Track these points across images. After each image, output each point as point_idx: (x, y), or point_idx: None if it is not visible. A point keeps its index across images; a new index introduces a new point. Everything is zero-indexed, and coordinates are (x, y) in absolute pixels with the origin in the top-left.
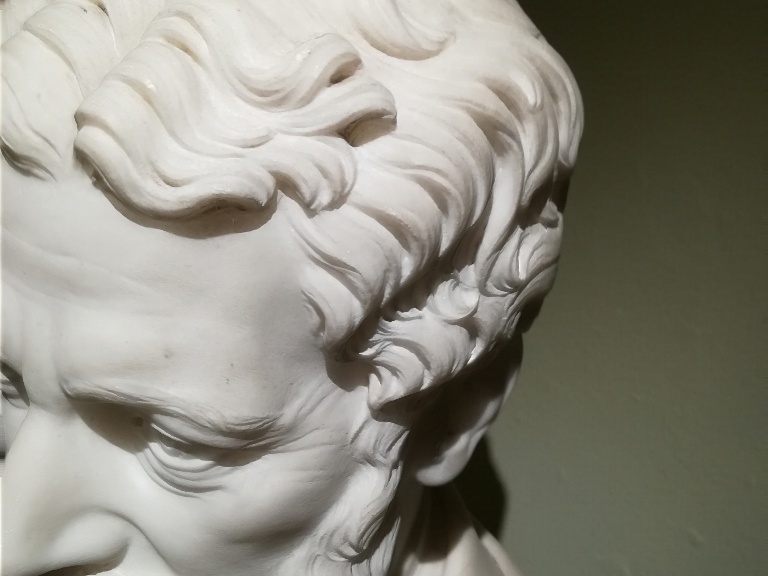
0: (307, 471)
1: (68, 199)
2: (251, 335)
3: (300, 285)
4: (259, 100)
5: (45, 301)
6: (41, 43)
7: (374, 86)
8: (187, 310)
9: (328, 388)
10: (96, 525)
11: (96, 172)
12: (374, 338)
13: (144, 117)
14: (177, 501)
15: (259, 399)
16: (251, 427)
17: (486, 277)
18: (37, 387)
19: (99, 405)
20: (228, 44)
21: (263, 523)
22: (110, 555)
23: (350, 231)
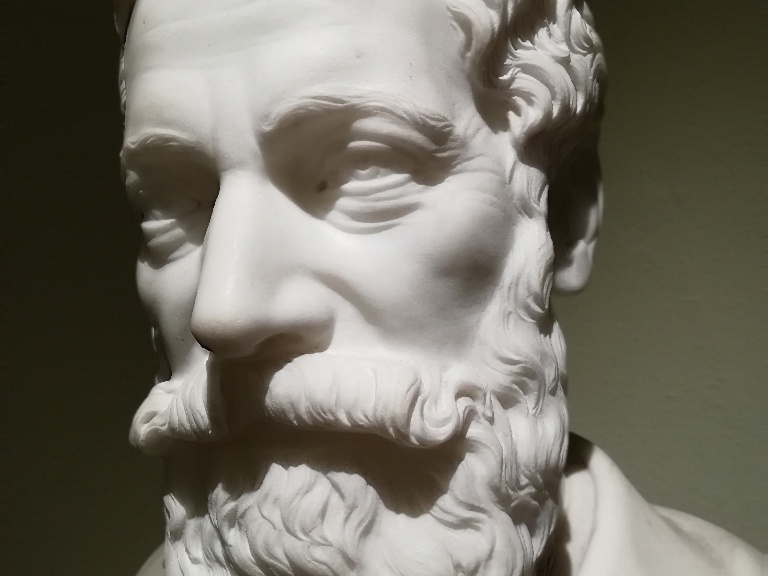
0: (485, 194)
1: None
2: (418, 42)
3: (445, 2)
4: None
5: (233, 59)
6: None
7: None
8: (365, 19)
9: (479, 122)
10: (305, 287)
11: None
12: (507, 62)
13: None
14: (379, 239)
15: (437, 100)
16: (437, 125)
17: (569, 30)
18: (233, 144)
19: (286, 168)
20: None
21: (463, 243)
22: (323, 320)
23: None
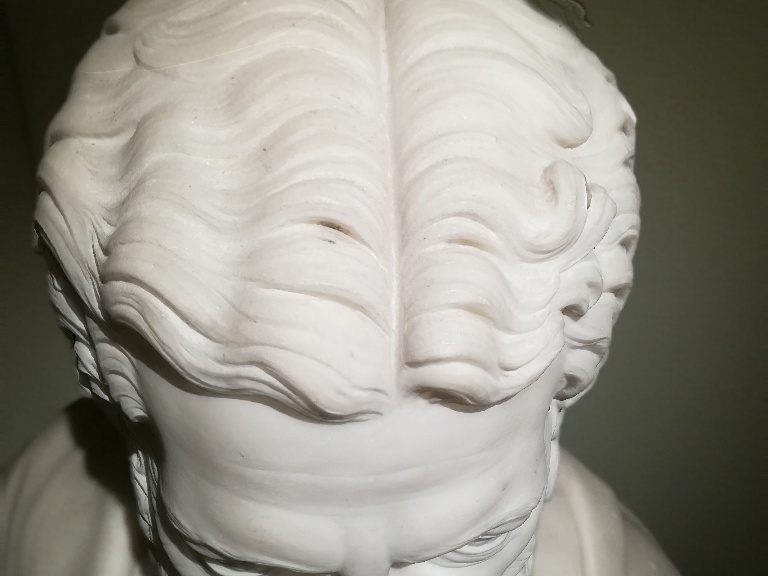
0: (546, 483)
1: (399, 424)
2: (541, 429)
3: (564, 371)
4: (543, 257)
5: (376, 510)
6: (313, 299)
7: (605, 194)
8: (510, 447)
9: None
10: None
11: (441, 394)
12: None
13: (486, 331)
14: (474, 569)
15: None
16: None
17: None
18: (372, 574)
19: None
20: (511, 223)
21: None
22: None
23: (602, 313)
